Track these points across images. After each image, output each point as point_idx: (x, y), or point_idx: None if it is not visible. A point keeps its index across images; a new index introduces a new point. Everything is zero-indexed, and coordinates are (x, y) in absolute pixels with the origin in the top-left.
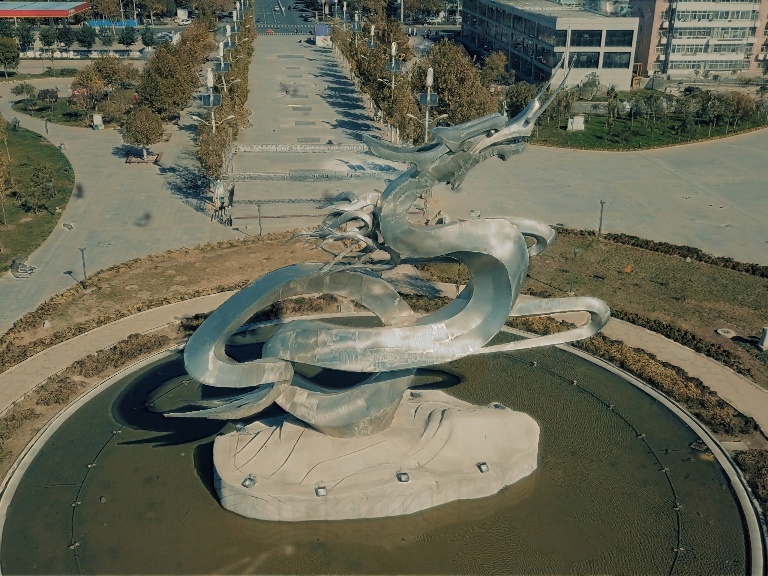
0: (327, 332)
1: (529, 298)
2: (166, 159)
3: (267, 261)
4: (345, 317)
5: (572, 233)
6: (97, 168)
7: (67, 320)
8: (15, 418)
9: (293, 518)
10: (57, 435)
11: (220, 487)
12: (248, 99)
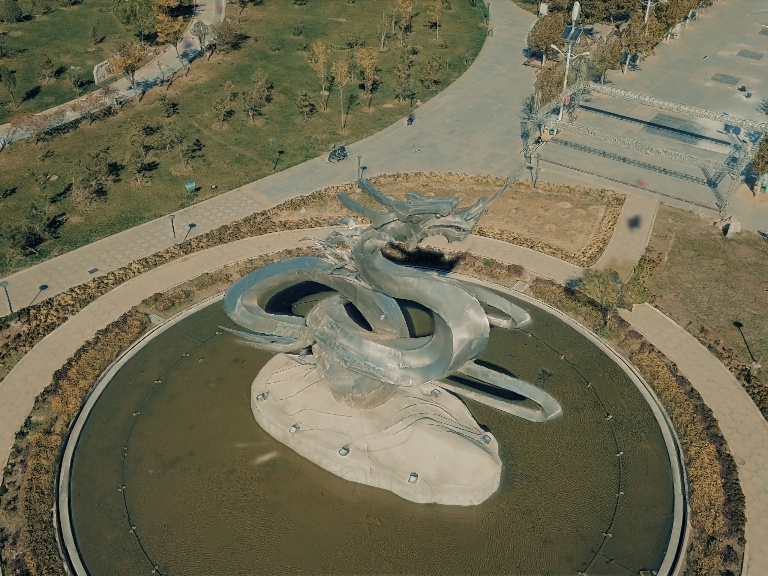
0: (328, 318)
1: (702, 350)
2: None
3: (515, 211)
4: (507, 294)
5: None
6: (494, 64)
7: (320, 211)
8: (212, 277)
9: (276, 436)
10: None
11: None
12: (728, 7)
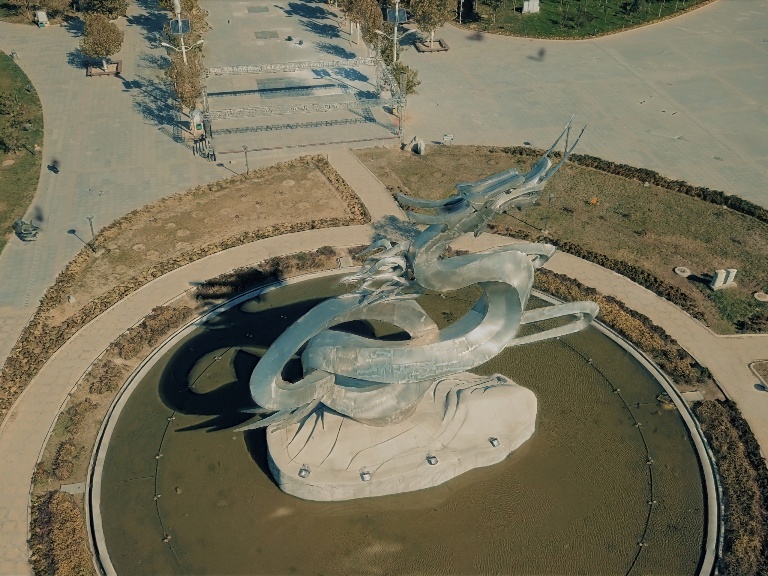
0: (365, 350)
1: (509, 240)
2: (127, 69)
3: (260, 206)
4: (346, 273)
5: (539, 155)
6: (59, 85)
7: (89, 292)
8: (77, 412)
9: (343, 498)
10: (119, 426)
11: (279, 476)
12: None
